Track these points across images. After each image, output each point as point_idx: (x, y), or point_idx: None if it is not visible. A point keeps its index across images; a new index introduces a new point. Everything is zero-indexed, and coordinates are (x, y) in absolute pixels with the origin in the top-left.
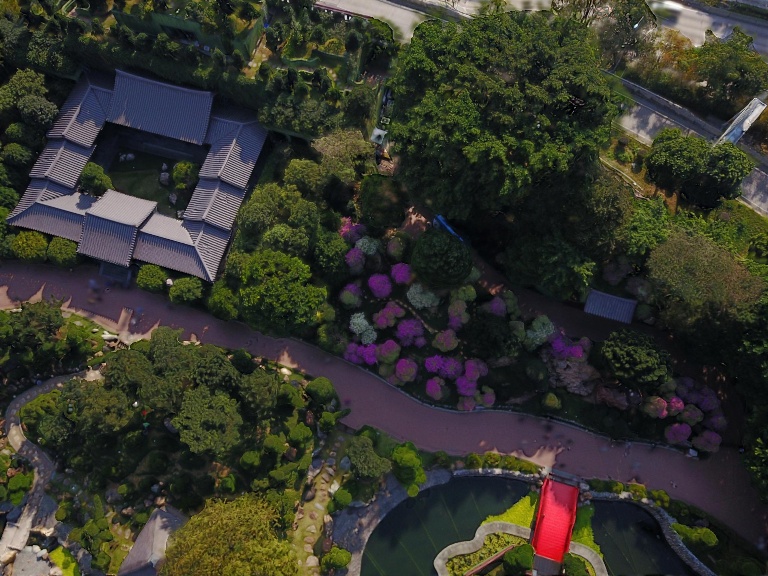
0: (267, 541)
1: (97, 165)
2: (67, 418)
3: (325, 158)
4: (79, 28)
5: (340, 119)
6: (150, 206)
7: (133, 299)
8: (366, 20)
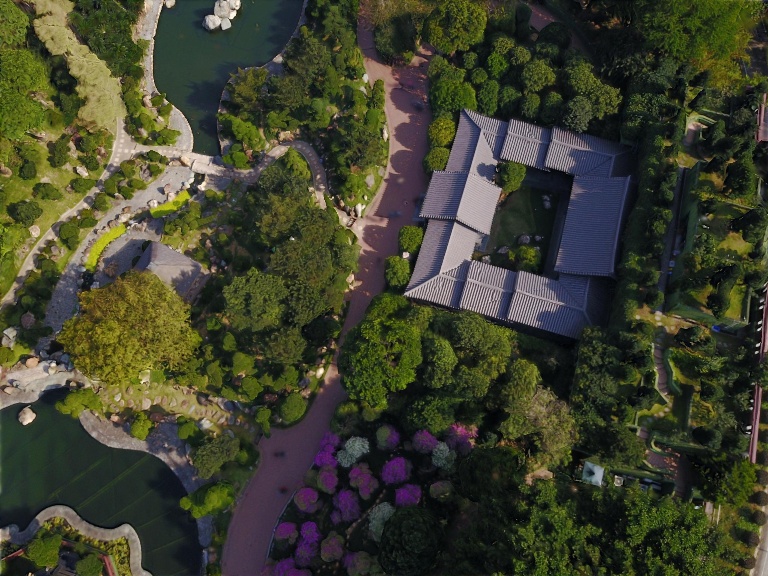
0: (140, 358)
1: (524, 175)
2: (281, 186)
3: (524, 402)
4: (671, 134)
5: (594, 421)
6: (484, 228)
7: (397, 226)
8: (748, 454)
